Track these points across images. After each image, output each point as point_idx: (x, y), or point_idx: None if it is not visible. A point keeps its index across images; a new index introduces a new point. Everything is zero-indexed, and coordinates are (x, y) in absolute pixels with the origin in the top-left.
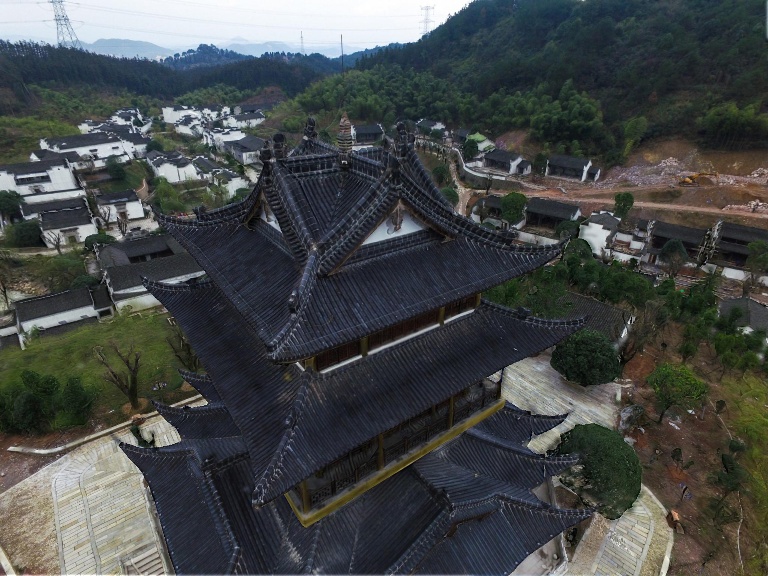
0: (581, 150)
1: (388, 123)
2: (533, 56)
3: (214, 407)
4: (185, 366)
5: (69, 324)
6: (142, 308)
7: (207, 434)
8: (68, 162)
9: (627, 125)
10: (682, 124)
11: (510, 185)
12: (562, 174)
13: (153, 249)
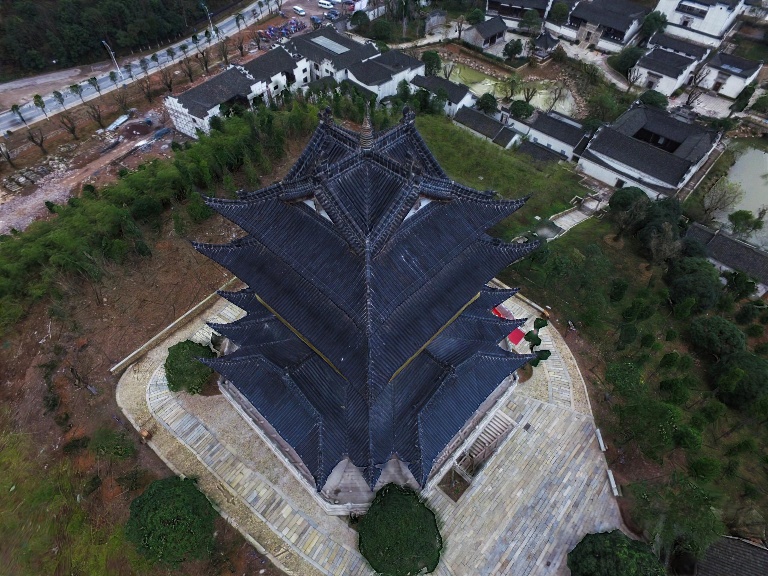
0: None
1: None
2: None
3: None
4: None
5: (543, 149)
6: (593, 175)
7: None
8: (742, 3)
9: None
10: None
11: None
12: None
13: (671, 135)
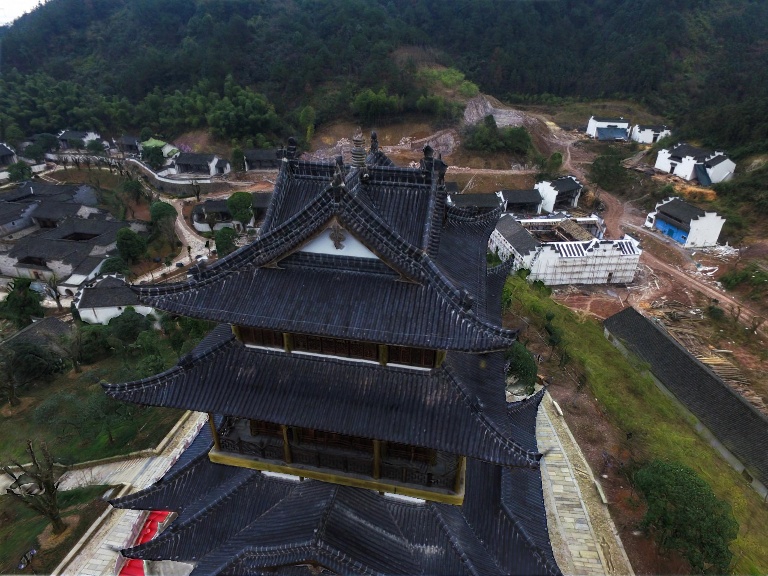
0: (268, 142)
1: (15, 141)
2: (172, 52)
3: (214, 503)
4: (43, 514)
5: None
6: None
7: (224, 535)
8: None
9: (300, 115)
10: (340, 109)
11: (218, 187)
12: (260, 167)
13: None
